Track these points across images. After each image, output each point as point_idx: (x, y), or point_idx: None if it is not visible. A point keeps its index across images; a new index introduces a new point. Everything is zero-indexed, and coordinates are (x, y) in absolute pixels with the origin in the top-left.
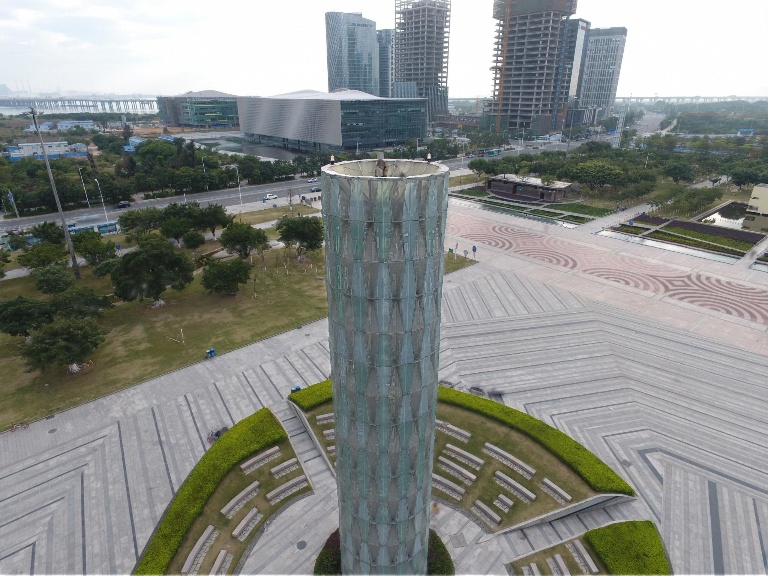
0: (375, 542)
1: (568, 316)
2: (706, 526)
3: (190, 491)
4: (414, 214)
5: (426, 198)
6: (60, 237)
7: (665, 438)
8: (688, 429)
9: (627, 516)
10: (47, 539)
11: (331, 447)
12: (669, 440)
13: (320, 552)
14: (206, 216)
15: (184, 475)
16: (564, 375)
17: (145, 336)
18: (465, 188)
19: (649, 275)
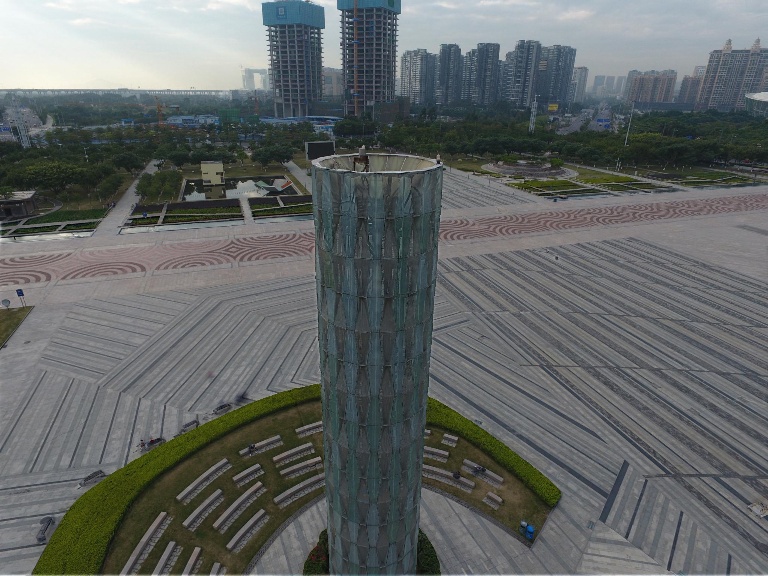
0: (414, 523)
1: (199, 309)
2: None
3: None
4: None
5: None
6: None
7: None
8: None
9: None
10: None
11: (183, 575)
12: None
13: None
14: None
15: None
16: (259, 351)
17: None
18: None
19: (209, 252)
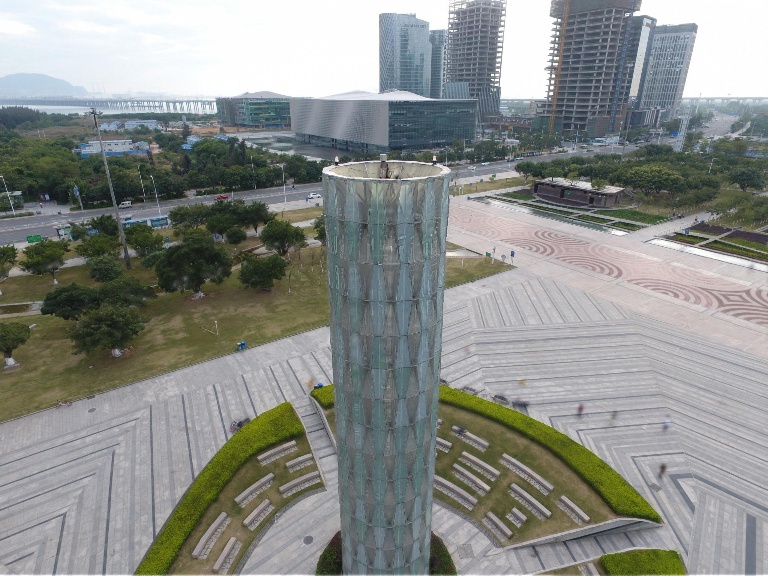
0: (372, 544)
1: (607, 327)
2: (739, 563)
3: (208, 477)
4: (409, 217)
5: (422, 201)
6: (115, 229)
7: (702, 464)
8: (729, 456)
9: (650, 543)
10: (76, 511)
11: None
12: (706, 466)
13: (325, 549)
14: (249, 213)
15: (205, 462)
16: (596, 389)
17: (183, 326)
18: (510, 191)
19: (702, 288)
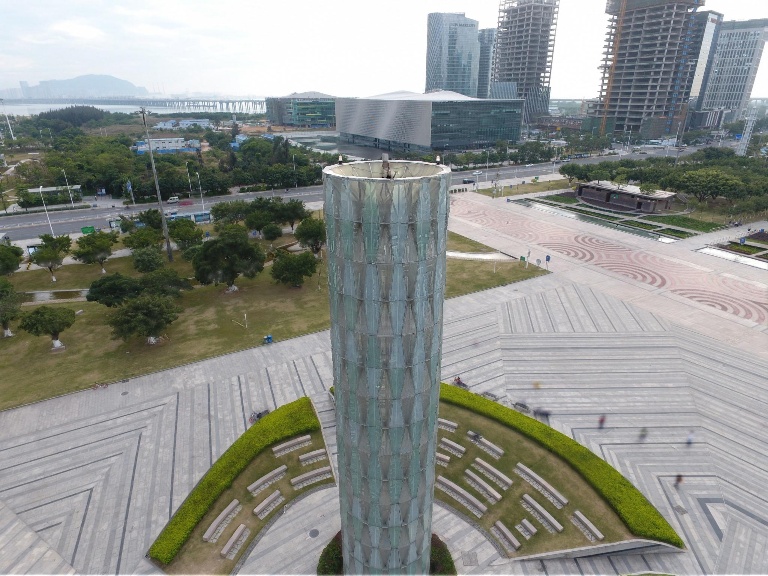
0: (367, 543)
1: (643, 339)
2: None
3: (224, 465)
4: (403, 217)
5: (417, 201)
6: (161, 223)
7: (736, 489)
8: None
9: (669, 569)
10: (102, 487)
11: None
12: (740, 492)
13: (328, 543)
14: (286, 210)
15: (223, 449)
16: (625, 403)
17: (215, 318)
18: (553, 194)
19: (754, 302)
